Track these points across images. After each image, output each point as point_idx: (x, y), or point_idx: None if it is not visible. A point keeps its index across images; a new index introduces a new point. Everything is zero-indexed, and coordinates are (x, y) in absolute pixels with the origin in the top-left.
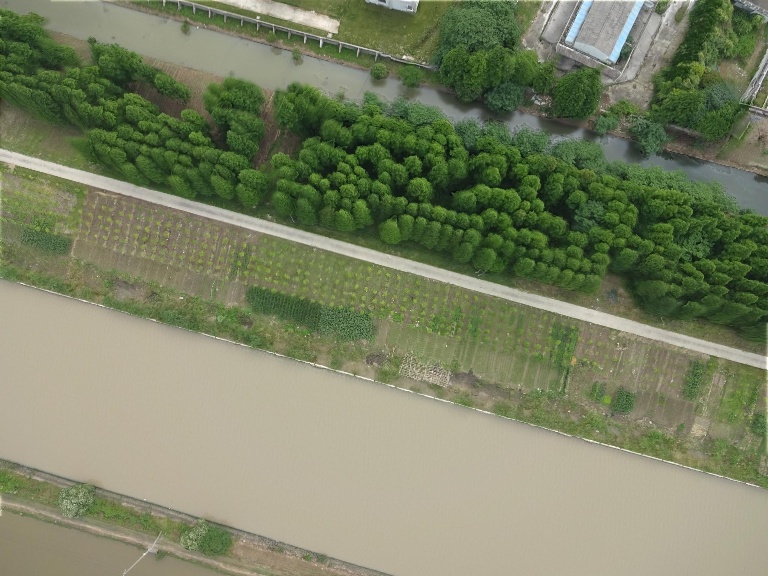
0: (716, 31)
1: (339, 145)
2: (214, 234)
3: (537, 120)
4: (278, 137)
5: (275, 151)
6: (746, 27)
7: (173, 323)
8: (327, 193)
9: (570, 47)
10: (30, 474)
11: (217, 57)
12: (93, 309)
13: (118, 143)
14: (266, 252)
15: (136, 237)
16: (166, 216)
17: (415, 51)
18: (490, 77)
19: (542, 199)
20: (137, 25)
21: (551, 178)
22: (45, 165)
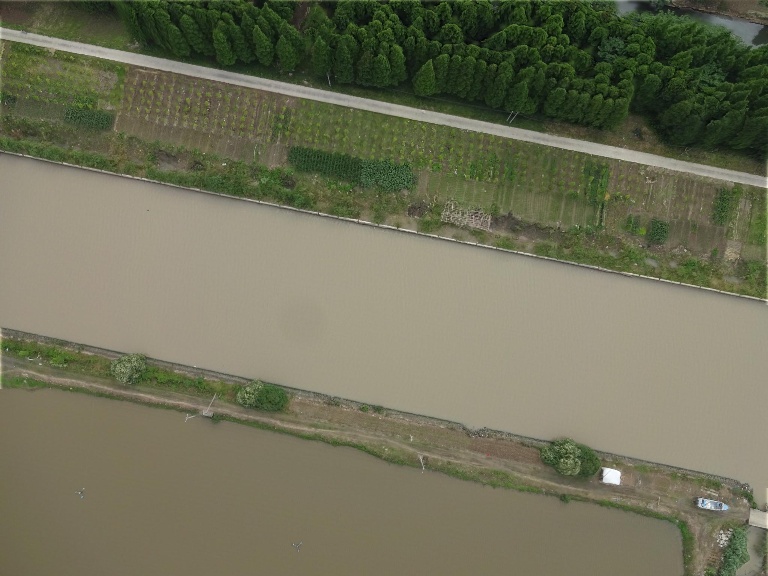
0: None
1: None
2: (253, 101)
3: None
4: (308, 14)
5: (306, 26)
6: None
7: (217, 188)
8: (365, 41)
9: None
10: (79, 348)
11: None
12: (136, 184)
13: (162, 5)
14: (305, 113)
15: (177, 109)
16: (206, 88)
17: None
18: None
19: (567, 34)
20: None
21: (573, 17)
22: (85, 48)
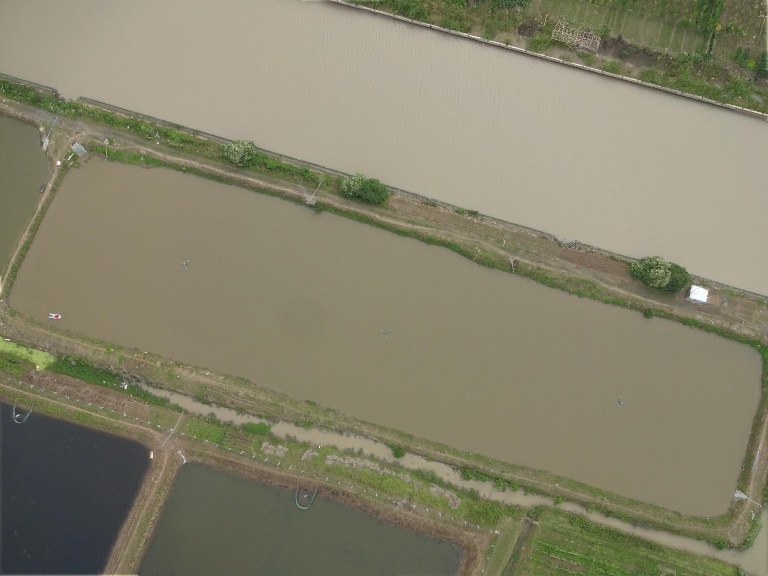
0: None
1: None
2: None
3: None
4: None
5: None
6: None
7: None
8: None
9: None
10: (194, 132)
11: None
12: None
13: None
14: None
15: None
16: None
17: None
18: None
19: None
20: None
21: None
22: None
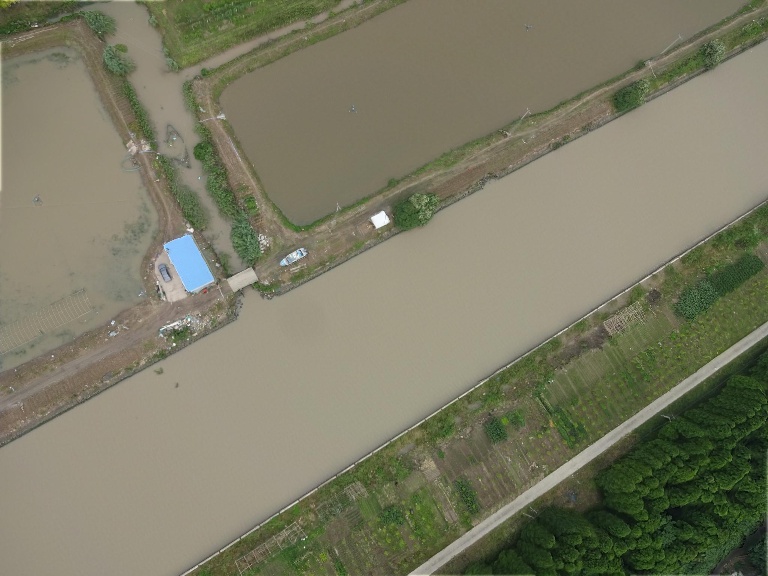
0: None
1: None
2: None
3: None
4: None
5: None
6: None
7: None
8: None
9: None
10: None
11: None
12: None
13: None
14: None
15: None
16: None
17: None
18: None
19: None
20: None
21: None
22: None
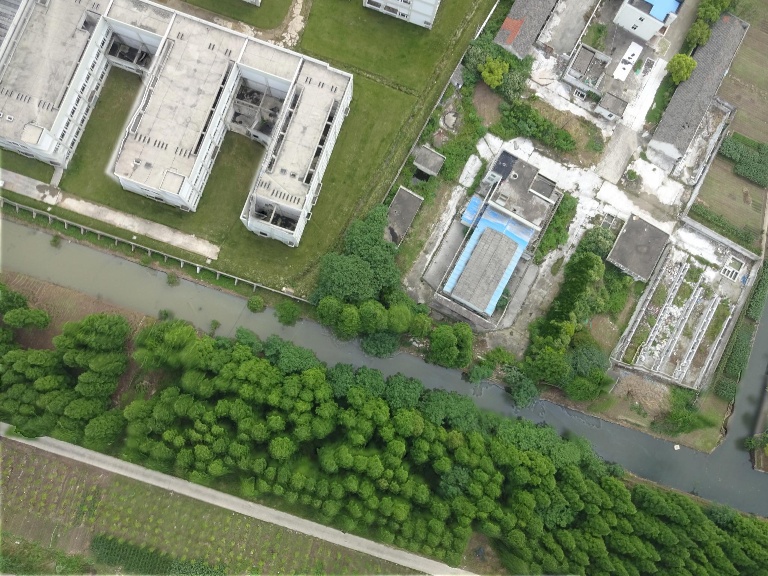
0: (587, 291)
1: (198, 399)
2: (61, 473)
3: (414, 363)
4: (145, 364)
5: (140, 379)
6: (617, 286)
7: (5, 571)
8: (181, 452)
9: (447, 297)
10: None
11: (87, 275)
12: None
13: None
14: (117, 497)
15: None
16: (9, 450)
17: (296, 283)
18: (365, 327)
19: (405, 469)
20: (2, 236)
21: (417, 443)
22: None
